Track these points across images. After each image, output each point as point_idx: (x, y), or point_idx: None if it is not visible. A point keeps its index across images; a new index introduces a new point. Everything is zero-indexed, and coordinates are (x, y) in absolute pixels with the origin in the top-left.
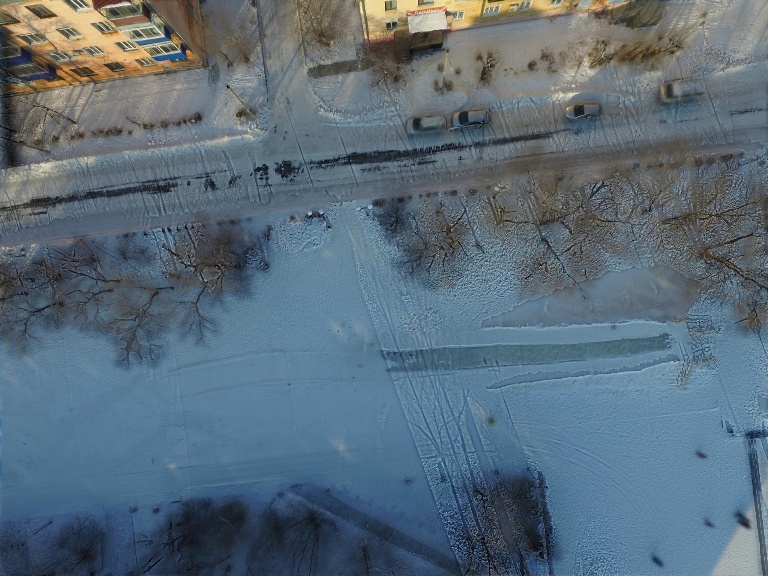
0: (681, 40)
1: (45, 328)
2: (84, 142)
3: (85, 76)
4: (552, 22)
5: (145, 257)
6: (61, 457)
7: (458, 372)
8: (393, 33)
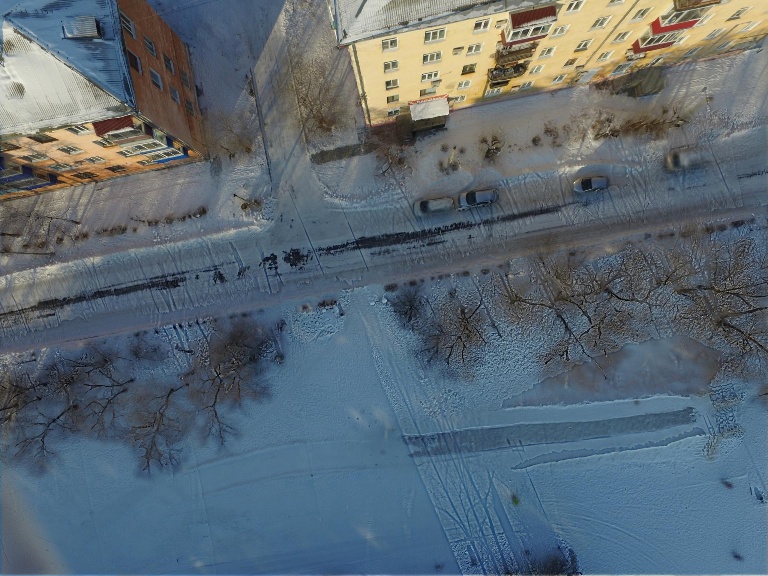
0: (684, 107)
1: (60, 432)
2: (89, 242)
3: (86, 178)
4: (553, 96)
5: (158, 355)
6: (85, 561)
7: (482, 454)
8: (395, 117)
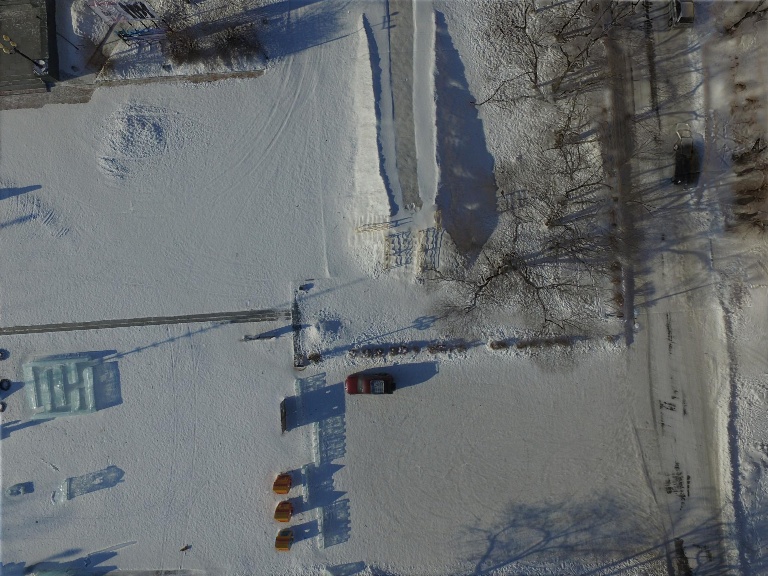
0: (759, 259)
1: None
2: None
3: None
4: None
5: None
6: None
7: None
8: None
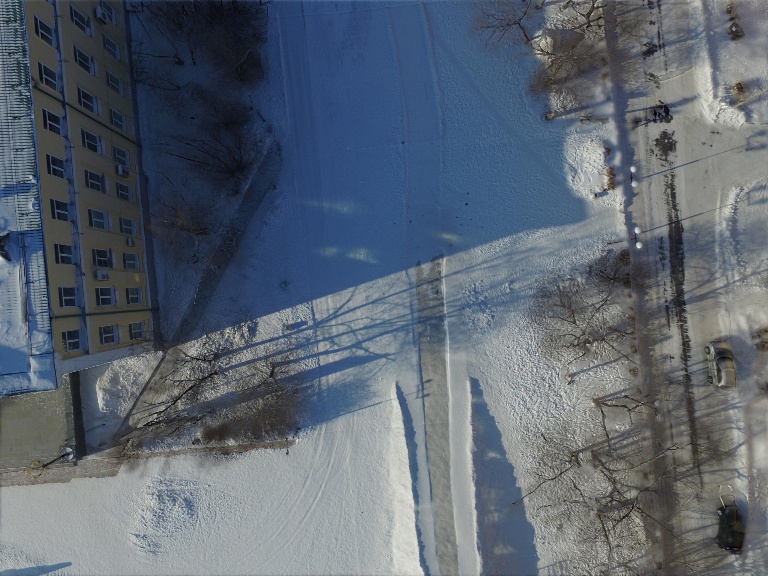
0: None
1: None
2: None
3: None
4: None
5: None
6: None
7: (416, 348)
8: None
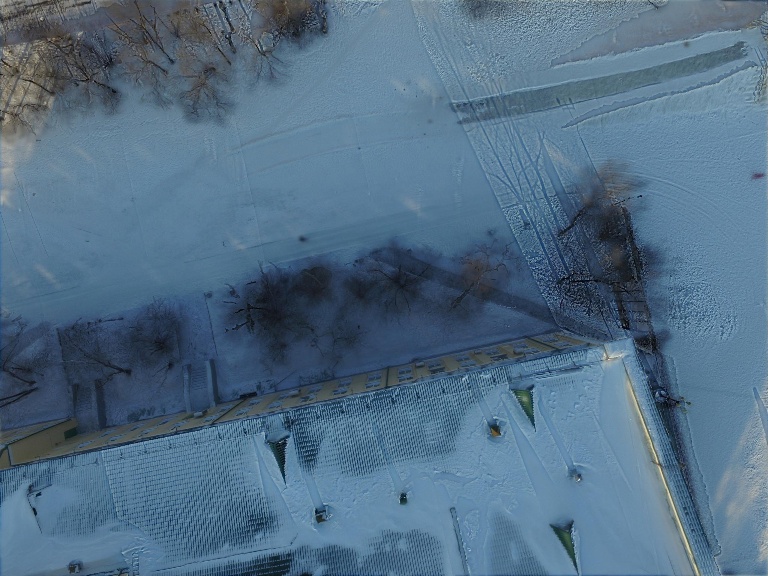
0: None
1: (99, 118)
2: None
3: None
4: None
5: None
6: (127, 251)
7: (532, 115)
8: None
